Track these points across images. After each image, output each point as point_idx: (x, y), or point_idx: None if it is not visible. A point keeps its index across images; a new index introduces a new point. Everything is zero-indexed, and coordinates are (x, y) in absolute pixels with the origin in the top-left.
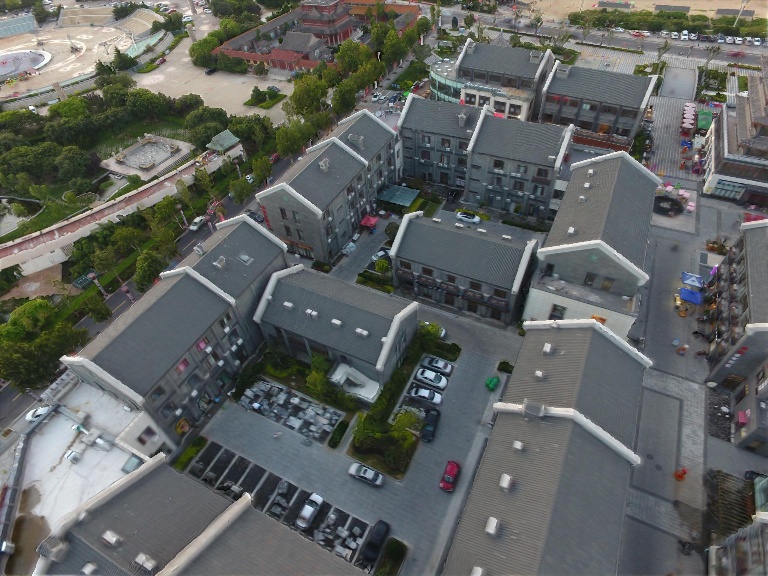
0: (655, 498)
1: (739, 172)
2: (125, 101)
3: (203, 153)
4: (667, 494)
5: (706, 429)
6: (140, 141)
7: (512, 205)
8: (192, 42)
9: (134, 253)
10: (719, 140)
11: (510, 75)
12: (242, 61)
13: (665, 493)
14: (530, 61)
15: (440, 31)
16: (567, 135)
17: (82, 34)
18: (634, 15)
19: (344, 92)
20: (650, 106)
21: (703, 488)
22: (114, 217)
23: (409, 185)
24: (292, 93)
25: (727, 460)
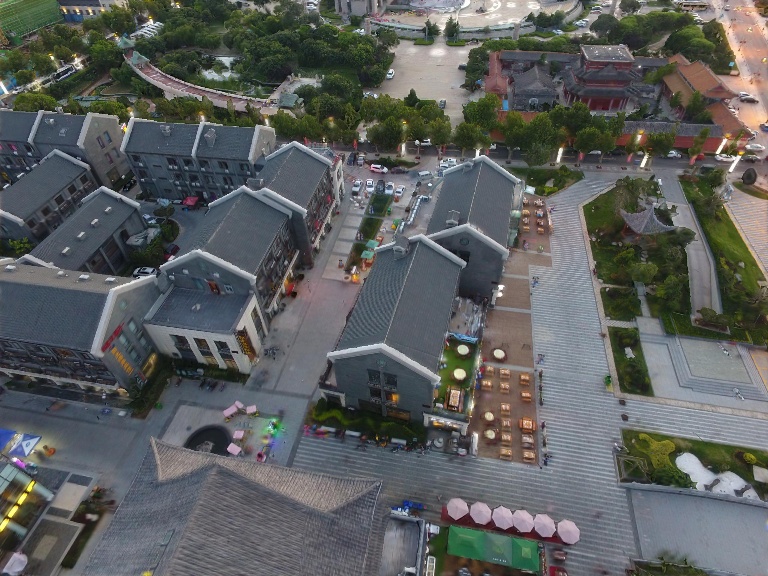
0: None
1: None
2: None
3: None
4: None
5: None
6: (316, 78)
7: None
8: None
9: (173, 120)
10: None
11: None
12: (476, 70)
13: None
14: None
15: (700, 170)
16: None
17: (515, 2)
18: None
19: None
20: None
21: None
22: (200, 98)
23: None
24: None
25: None
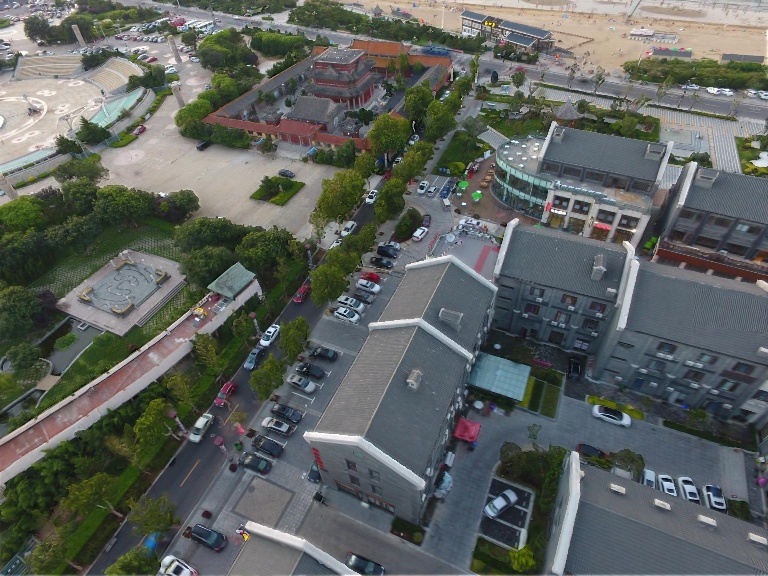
0: None
1: None
2: (92, 205)
3: (204, 297)
4: None
5: None
6: (113, 265)
7: (674, 394)
8: (178, 104)
9: None
10: None
11: (618, 174)
12: (243, 134)
13: None
14: (646, 156)
15: (480, 89)
16: None
17: (43, 89)
18: (699, 66)
19: (391, 194)
20: None
21: None
22: (71, 431)
23: (513, 358)
24: (311, 179)
25: None
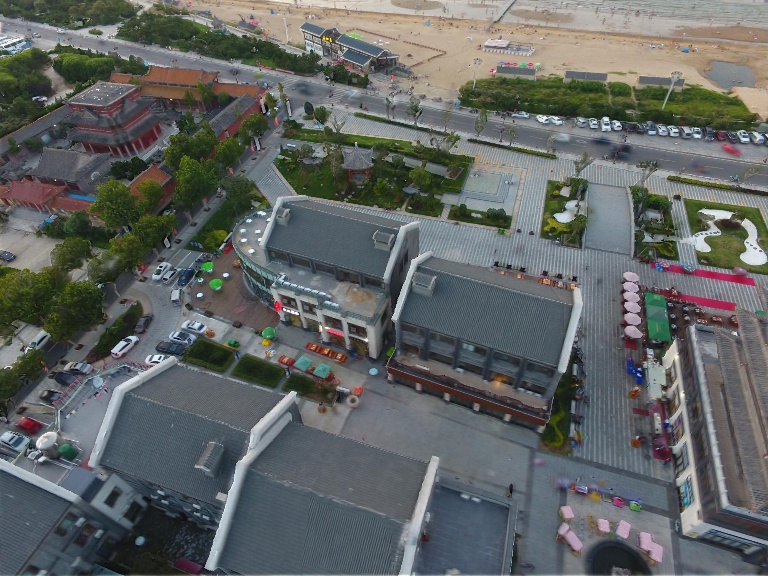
0: None
1: (749, 526)
2: None
3: None
4: None
5: None
6: None
7: None
8: None
9: None
10: (698, 426)
11: (345, 269)
12: None
13: None
14: (375, 246)
15: (287, 124)
16: (407, 554)
17: None
18: (541, 86)
19: (69, 304)
20: (573, 277)
21: None
22: None
23: (130, 575)
24: (32, 263)
25: None
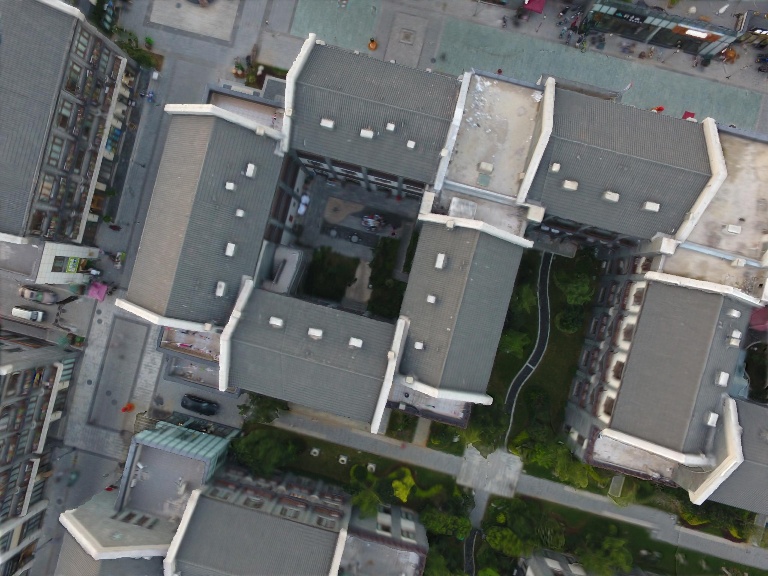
0: (106, 431)
1: None
2: None
3: None
4: (117, 425)
5: (164, 355)
6: None
7: None
8: None
9: None
10: None
11: None
12: None
13: (115, 425)
14: None
15: None
16: None
17: None
18: None
19: None
20: None
21: (147, 415)
22: None
23: None
24: None
25: (174, 384)
